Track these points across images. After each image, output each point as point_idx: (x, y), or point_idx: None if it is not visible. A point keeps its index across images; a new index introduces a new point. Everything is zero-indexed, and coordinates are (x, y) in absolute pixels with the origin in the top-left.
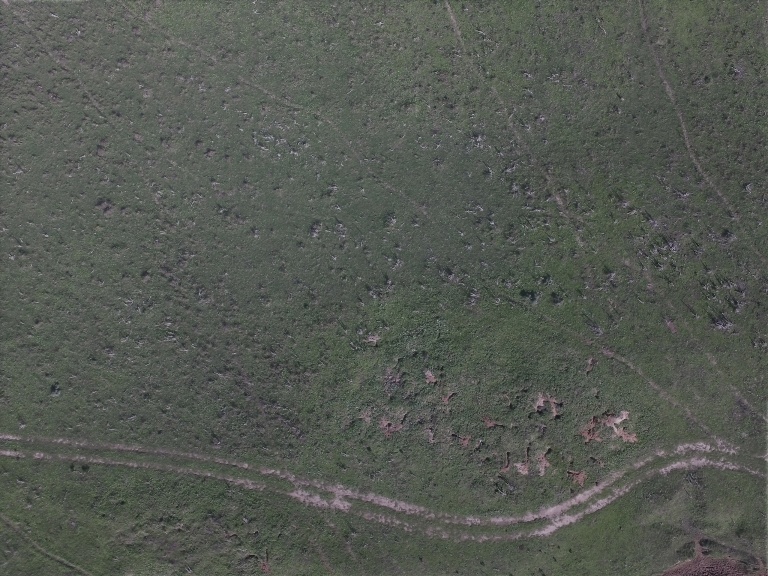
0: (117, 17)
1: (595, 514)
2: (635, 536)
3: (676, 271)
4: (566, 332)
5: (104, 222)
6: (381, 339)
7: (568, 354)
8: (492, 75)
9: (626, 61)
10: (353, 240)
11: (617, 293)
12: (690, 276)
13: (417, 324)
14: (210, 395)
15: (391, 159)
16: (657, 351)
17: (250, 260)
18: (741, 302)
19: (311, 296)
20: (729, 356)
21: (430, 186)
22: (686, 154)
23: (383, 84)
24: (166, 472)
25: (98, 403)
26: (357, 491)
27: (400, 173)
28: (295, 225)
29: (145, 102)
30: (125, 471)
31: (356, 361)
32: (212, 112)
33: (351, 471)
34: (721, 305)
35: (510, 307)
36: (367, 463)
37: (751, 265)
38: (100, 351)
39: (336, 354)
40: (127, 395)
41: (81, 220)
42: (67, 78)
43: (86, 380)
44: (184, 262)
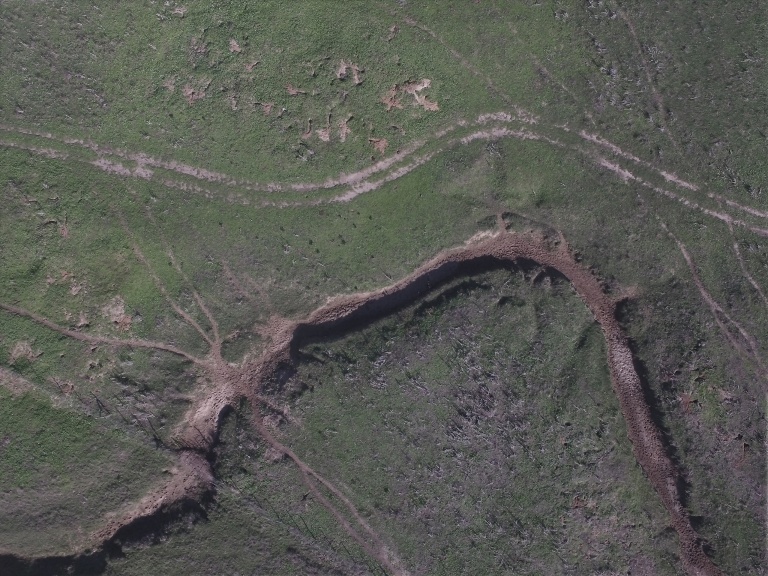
0: None
1: (395, 181)
2: (435, 204)
3: None
4: (371, 3)
5: None
6: (188, 11)
7: (371, 22)
8: None
9: None
10: None
11: None
12: None
13: None
14: (15, 67)
15: None
16: (459, 20)
17: None
18: None
19: None
20: (530, 25)
21: None
22: None
23: None
24: None
25: None
26: (160, 159)
27: None
28: None
29: None
30: None
31: (162, 31)
32: None
33: (154, 139)
34: None
35: None
36: (170, 131)
37: None
38: None
39: (142, 25)
40: None
41: None
42: None
43: None
44: None
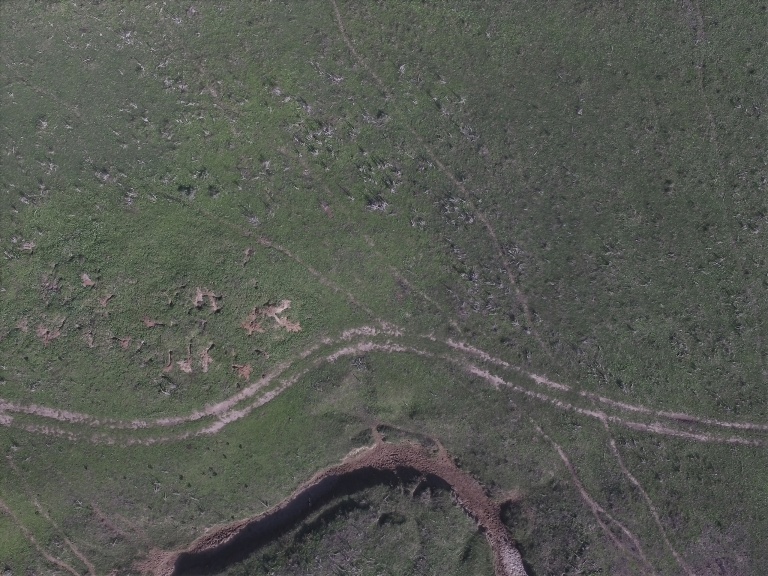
0: None
1: (263, 407)
2: (305, 426)
3: (332, 156)
4: (224, 225)
5: None
6: (36, 246)
7: (225, 246)
8: None
9: None
10: (5, 147)
11: (273, 181)
12: (347, 160)
13: (73, 228)
14: None
15: (40, 61)
16: (315, 237)
17: None
18: (397, 182)
19: None
20: (386, 236)
21: (82, 87)
22: (340, 38)
23: None
24: None
25: None
26: (18, 404)
27: (50, 75)
28: None
29: None
30: None
31: (10, 270)
32: None
33: (11, 384)
34: (378, 186)
35: (168, 204)
36: (26, 374)
37: (407, 145)
38: None
39: None
40: None
41: None
42: None
43: None
44: None
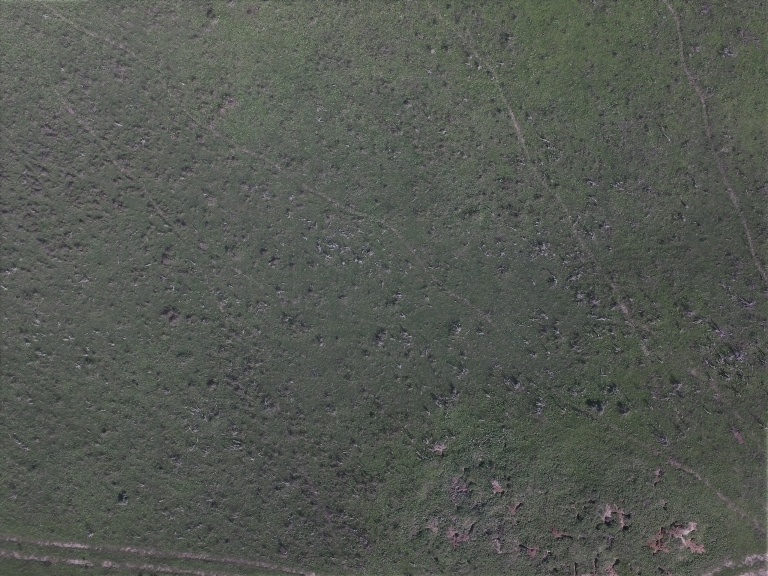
0: (181, 126)
1: None
2: None
3: (743, 381)
4: (633, 442)
5: (170, 330)
6: (447, 448)
7: (635, 465)
8: (556, 183)
9: (690, 169)
10: (418, 348)
11: (684, 403)
12: (757, 386)
13: (483, 433)
14: (277, 503)
15: (455, 267)
16: (725, 462)
17: (315, 368)
18: None
19: (377, 405)
20: None
21: (495, 294)
22: (751, 262)
23: (447, 192)
24: None
25: (165, 512)
26: None
27: (464, 281)
28: (360, 333)
29: (209, 210)
30: None
31: (423, 471)
32: (276, 220)
33: None
34: None
35: (576, 416)
36: (435, 573)
37: None
38: (167, 459)
39: (402, 463)
40: (194, 504)
41: (147, 328)
42: (132, 187)
43: (153, 488)
44: (250, 371)
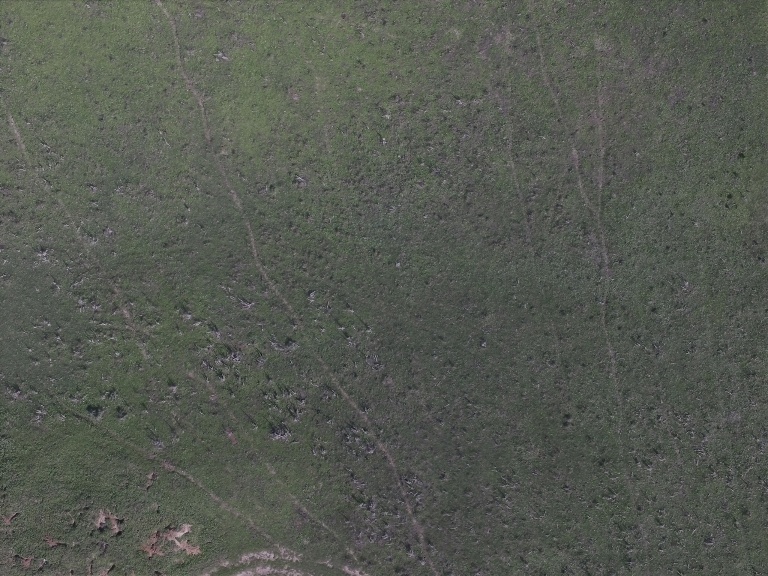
0: None
1: None
2: None
3: (239, 381)
4: (130, 447)
5: None
6: None
7: (129, 469)
8: (58, 188)
9: (192, 172)
10: None
11: (180, 406)
12: (253, 386)
13: None
14: None
15: None
16: (218, 463)
17: None
18: (301, 411)
19: None
20: (288, 465)
21: None
22: (253, 263)
23: None
24: None
25: None
26: None
27: None
28: None
29: None
30: None
31: None
32: None
33: None
34: (282, 414)
35: (76, 423)
36: None
37: (313, 373)
38: None
39: None
40: None
41: None
42: None
43: None
44: None
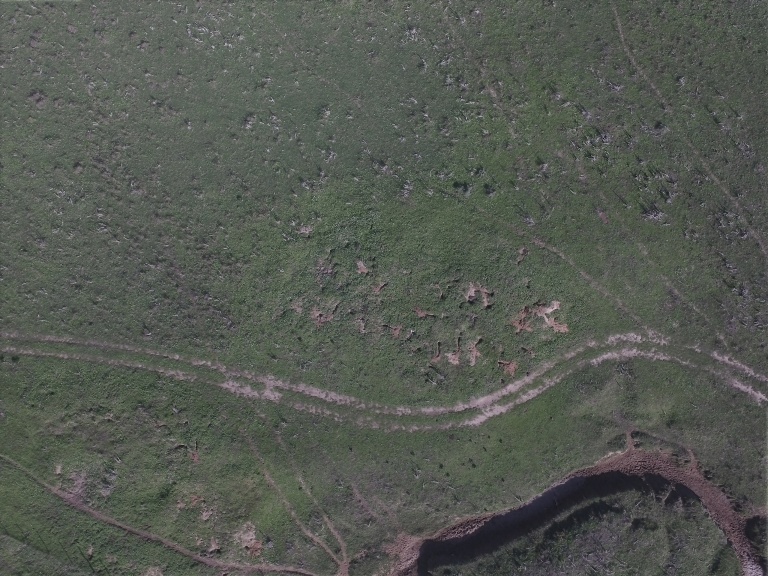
0: None
1: (526, 404)
2: (565, 426)
3: (609, 162)
4: (498, 223)
5: (36, 113)
6: (313, 230)
7: (500, 244)
8: None
9: None
10: (287, 132)
11: (549, 184)
12: (623, 168)
13: (350, 216)
14: (142, 287)
15: (326, 52)
16: (588, 241)
17: (183, 152)
18: (673, 193)
19: (244, 188)
20: (660, 246)
21: (364, 79)
22: (620, 47)
23: None
24: (97, 363)
25: (29, 294)
26: (288, 382)
27: (335, 66)
28: (229, 117)
29: None
30: (55, 362)
31: (288, 252)
32: (146, 4)
33: (282, 362)
34: (653, 196)
35: (443, 199)
36: (298, 353)
37: (683, 157)
38: (31, 242)
39: (268, 245)
40: (58, 286)
41: (13, 111)
42: None
43: (17, 271)
44: (116, 153)
